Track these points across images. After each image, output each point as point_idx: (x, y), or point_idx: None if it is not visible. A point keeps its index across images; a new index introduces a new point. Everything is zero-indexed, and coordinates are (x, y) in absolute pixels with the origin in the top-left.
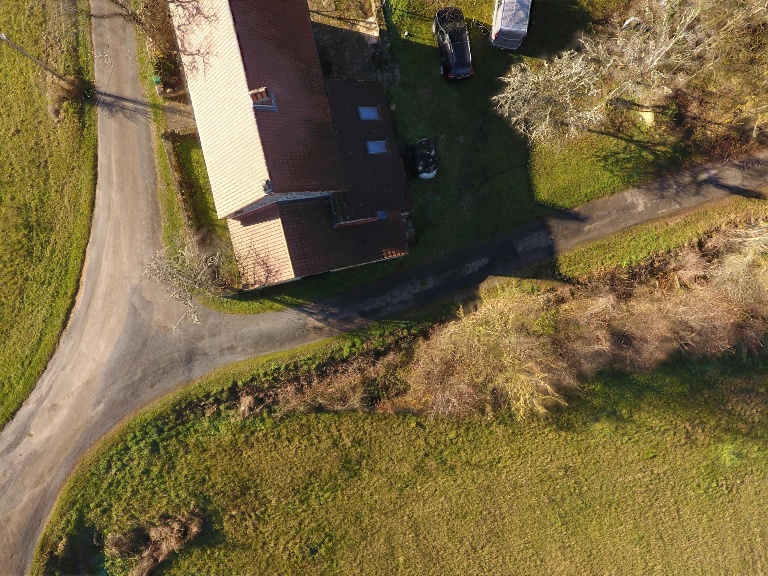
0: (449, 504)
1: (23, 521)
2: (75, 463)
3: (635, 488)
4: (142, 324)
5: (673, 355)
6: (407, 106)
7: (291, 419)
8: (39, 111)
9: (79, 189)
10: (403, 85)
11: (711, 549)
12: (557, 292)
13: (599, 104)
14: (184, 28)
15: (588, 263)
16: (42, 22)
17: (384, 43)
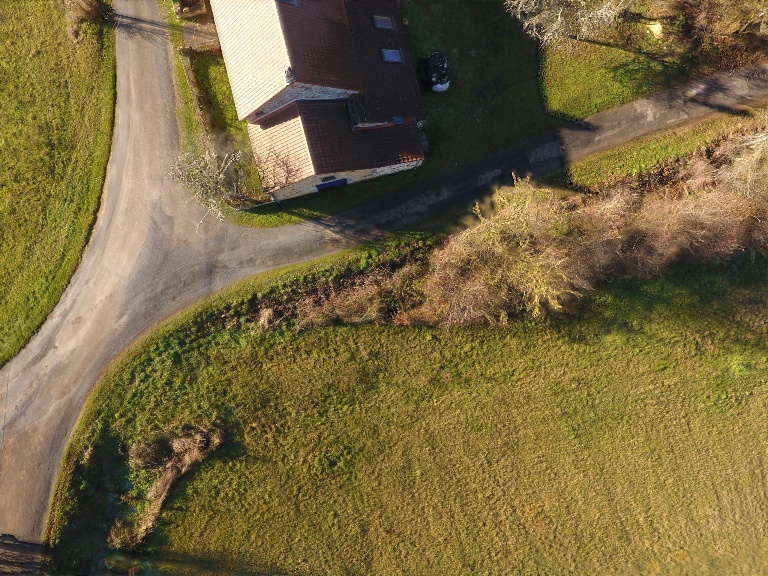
0: (465, 417)
1: (50, 430)
2: (100, 374)
3: (646, 400)
4: (163, 238)
5: (682, 266)
6: (419, 21)
7: (309, 332)
8: (58, 33)
9: (99, 108)
10: (415, 1)
11: (721, 463)
12: (569, 201)
13: None
14: None
15: (599, 173)
16: None
17: None
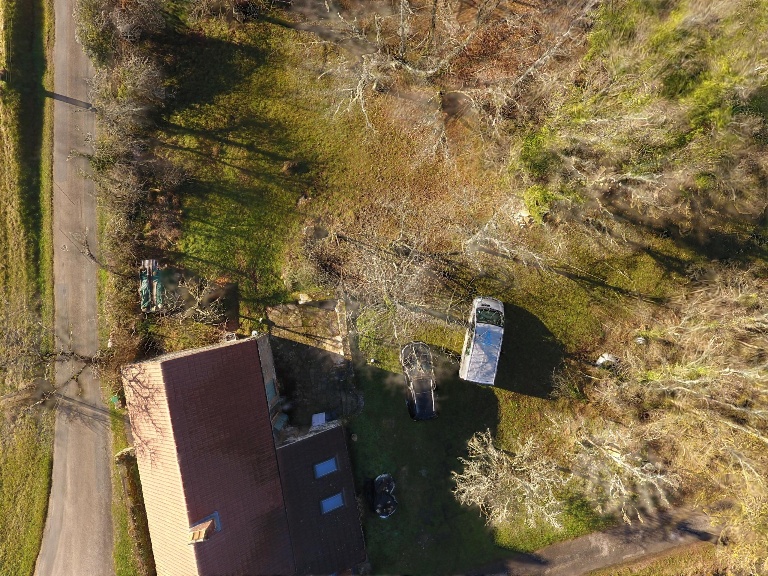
0: None
1: None
2: None
3: None
4: None
5: None
6: (369, 437)
7: None
8: None
9: (32, 498)
10: (366, 414)
11: None
12: None
13: (557, 512)
14: (134, 410)
15: None
16: (4, 320)
17: (348, 373)
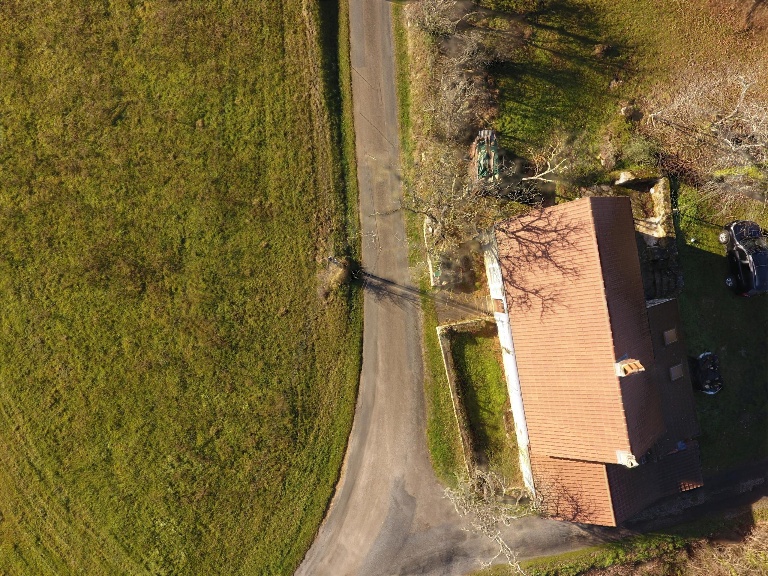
0: None
1: None
2: None
3: None
4: (404, 520)
5: None
6: (689, 316)
7: None
8: (308, 291)
9: (344, 374)
10: (686, 293)
11: None
12: None
13: None
14: (516, 262)
15: None
16: (313, 199)
17: (672, 251)
